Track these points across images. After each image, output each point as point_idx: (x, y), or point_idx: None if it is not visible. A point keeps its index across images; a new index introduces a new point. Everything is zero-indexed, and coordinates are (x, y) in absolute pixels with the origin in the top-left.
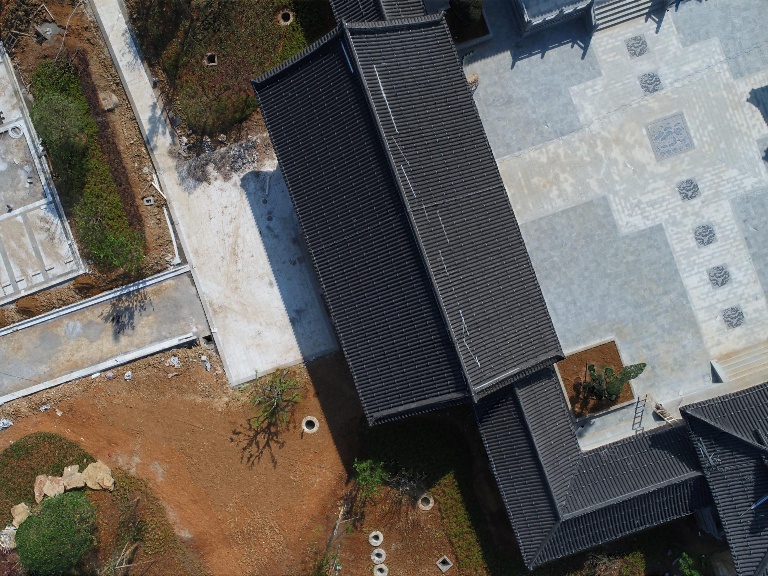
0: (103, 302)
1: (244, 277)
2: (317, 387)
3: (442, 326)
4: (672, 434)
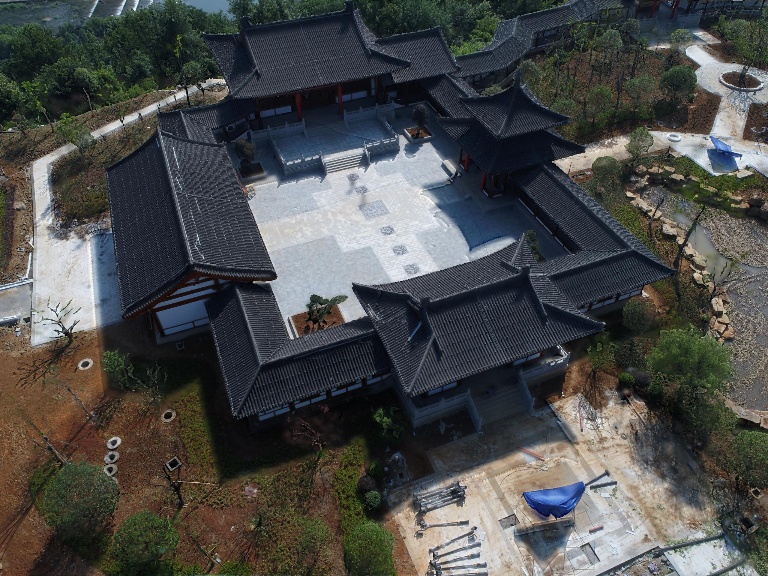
0: None
1: (71, 284)
2: (101, 342)
3: (181, 238)
4: (360, 322)
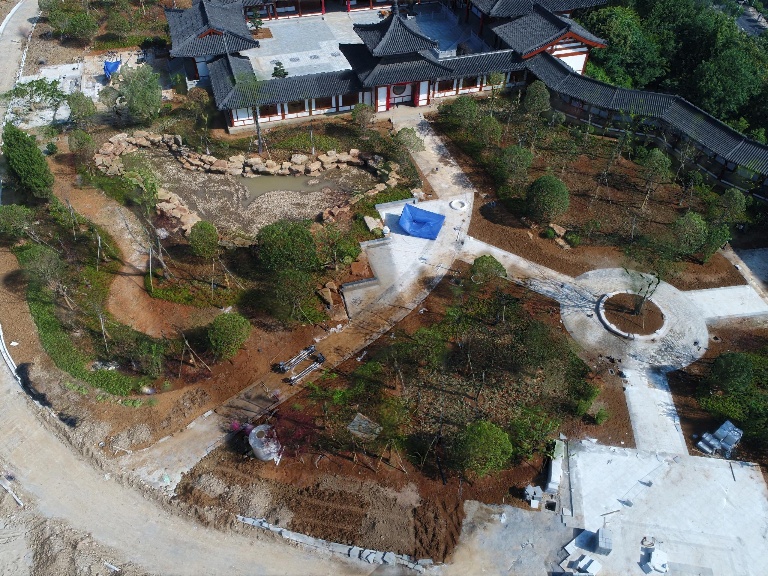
0: None
1: None
2: None
3: None
4: None
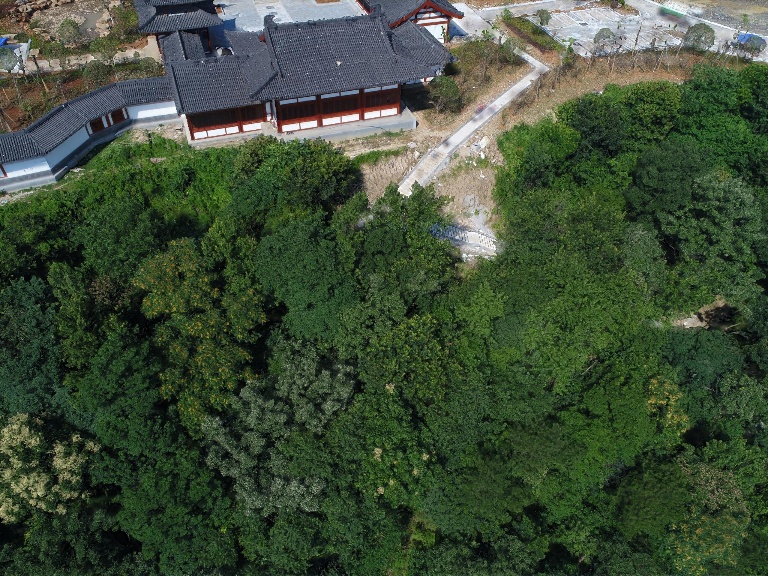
0: None
1: None
2: None
3: None
4: None
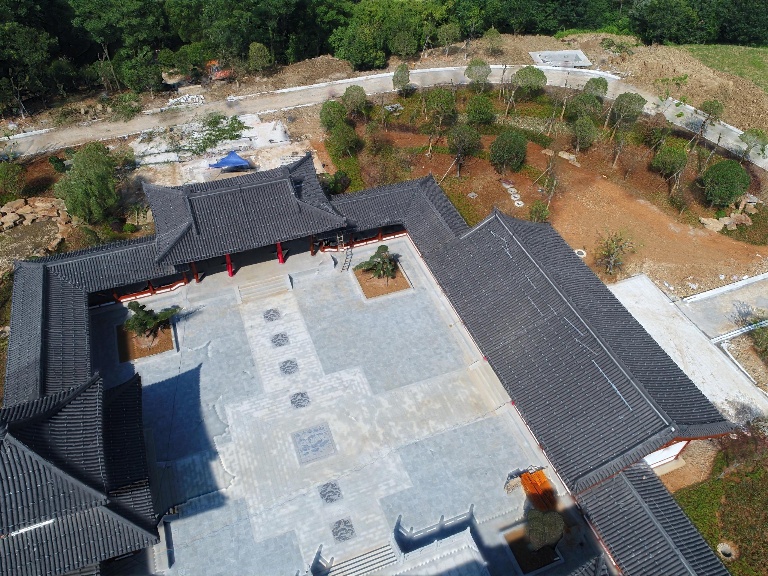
0: (767, 319)
1: (665, 336)
2: None
3: None
4: (342, 228)
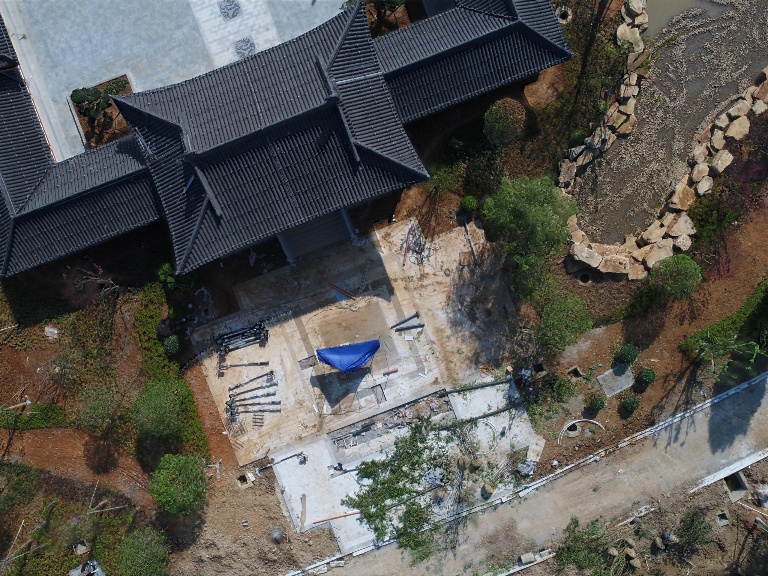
0: None
1: None
2: None
3: None
4: None
